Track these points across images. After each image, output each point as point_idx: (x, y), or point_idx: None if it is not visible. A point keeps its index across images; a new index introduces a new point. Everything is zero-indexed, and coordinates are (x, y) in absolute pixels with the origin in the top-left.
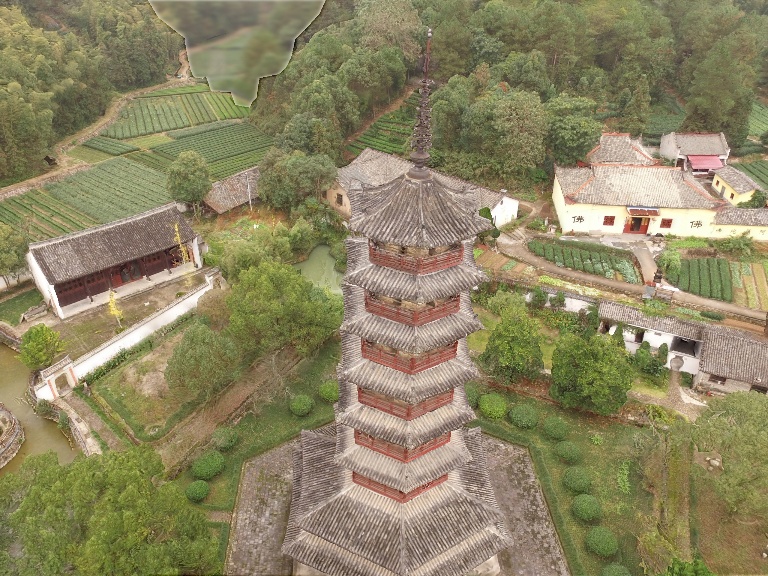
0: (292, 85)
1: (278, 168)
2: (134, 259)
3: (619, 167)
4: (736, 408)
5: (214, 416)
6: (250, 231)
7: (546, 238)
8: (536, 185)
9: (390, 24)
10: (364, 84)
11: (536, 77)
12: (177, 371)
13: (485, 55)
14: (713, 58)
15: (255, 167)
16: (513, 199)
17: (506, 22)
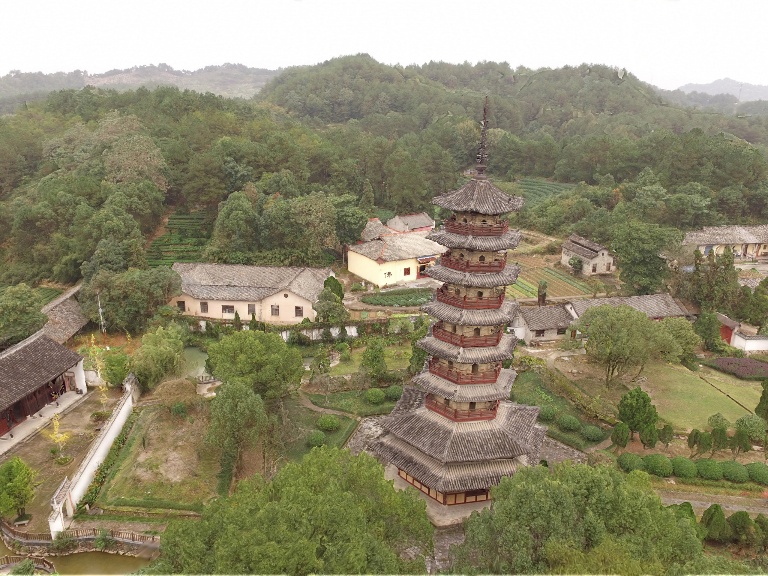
0: (48, 225)
1: (122, 285)
2: (34, 390)
3: (397, 235)
4: (599, 311)
5: (251, 474)
6: (103, 354)
7: (371, 294)
8: (331, 265)
9: (142, 160)
10: (139, 212)
11: (293, 189)
12: (230, 429)
13: (241, 178)
14: (405, 164)
15: (58, 302)
16: (333, 273)
17: (249, 152)
